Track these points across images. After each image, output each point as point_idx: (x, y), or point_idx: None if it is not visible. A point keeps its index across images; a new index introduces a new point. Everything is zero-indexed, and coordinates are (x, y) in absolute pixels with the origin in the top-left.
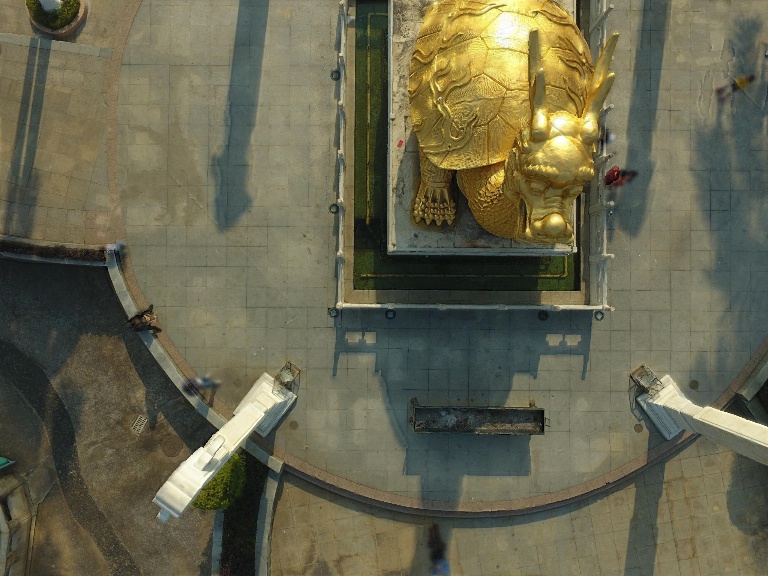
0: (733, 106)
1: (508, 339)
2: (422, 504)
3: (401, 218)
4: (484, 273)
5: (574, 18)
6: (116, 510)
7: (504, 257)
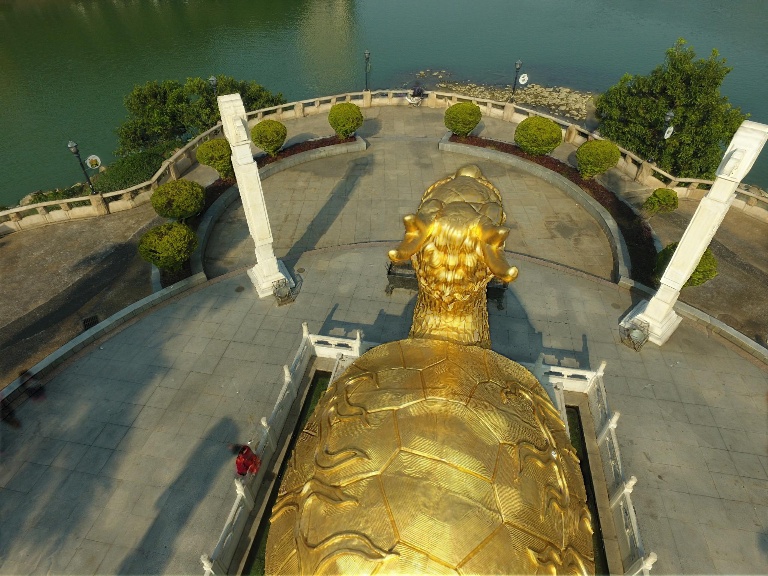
0: None
1: None
2: None
3: None
4: None
5: None
6: (759, 288)
7: None
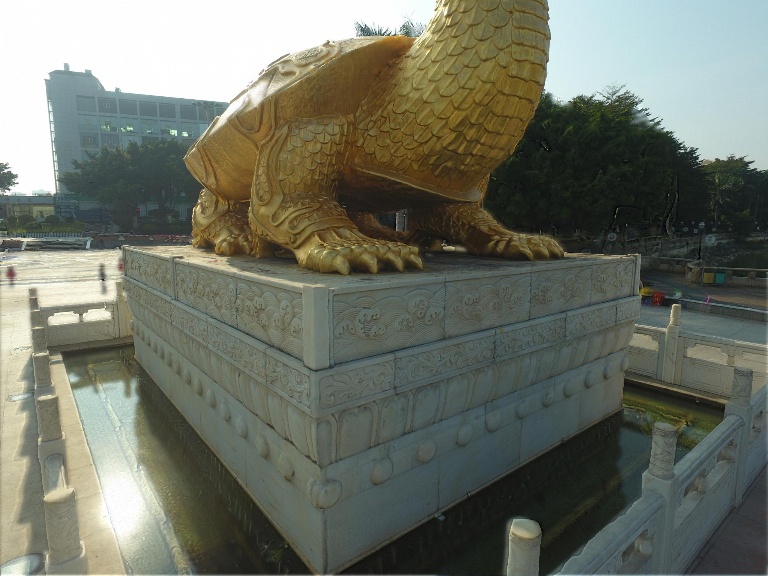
0: None
1: None
2: None
3: (295, 277)
4: (597, 493)
5: None
6: None
7: (580, 436)
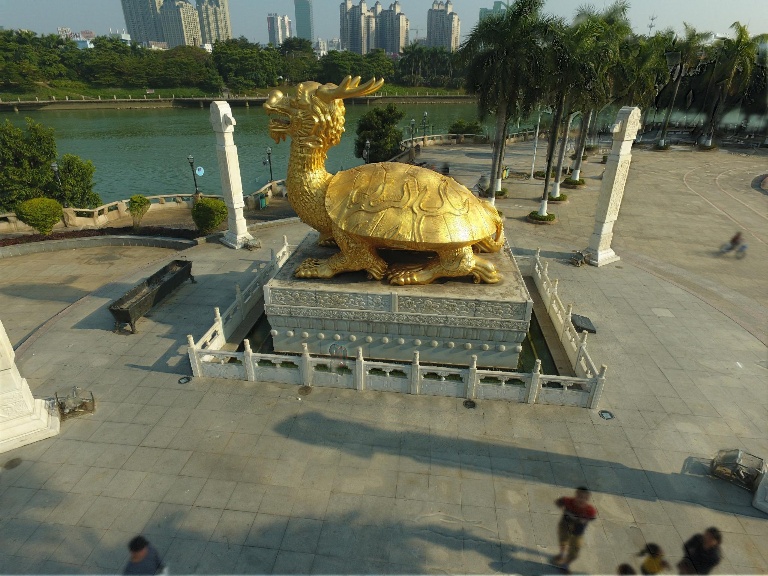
0: (437, 575)
1: (207, 324)
2: (113, 282)
3: None
4: None
5: (498, 299)
6: None
7: None
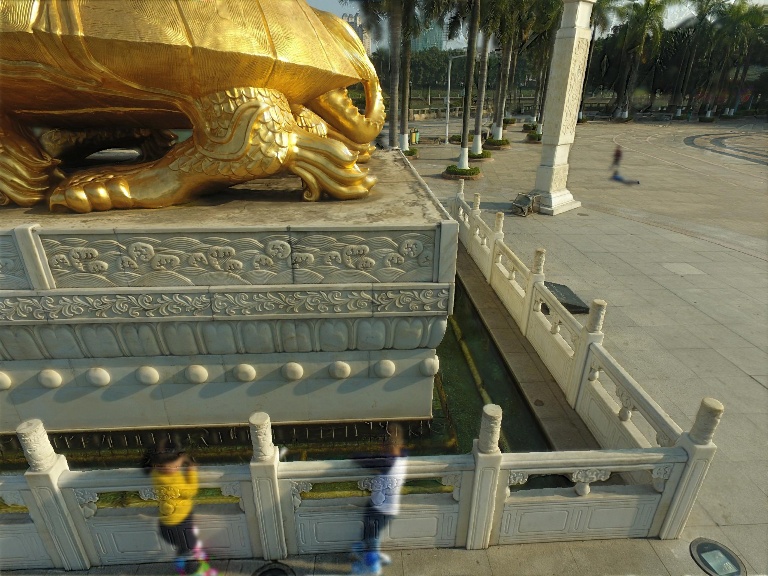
0: None
1: None
2: None
3: None
4: None
5: (356, 225)
6: None
7: None
